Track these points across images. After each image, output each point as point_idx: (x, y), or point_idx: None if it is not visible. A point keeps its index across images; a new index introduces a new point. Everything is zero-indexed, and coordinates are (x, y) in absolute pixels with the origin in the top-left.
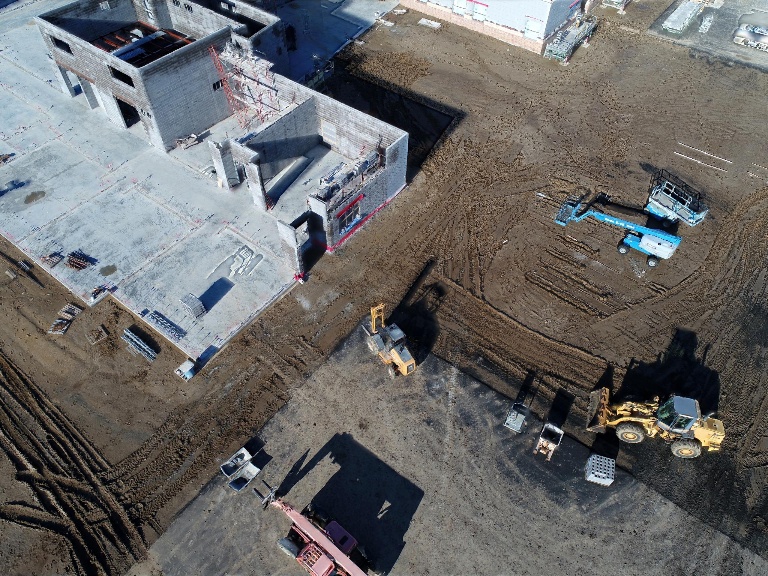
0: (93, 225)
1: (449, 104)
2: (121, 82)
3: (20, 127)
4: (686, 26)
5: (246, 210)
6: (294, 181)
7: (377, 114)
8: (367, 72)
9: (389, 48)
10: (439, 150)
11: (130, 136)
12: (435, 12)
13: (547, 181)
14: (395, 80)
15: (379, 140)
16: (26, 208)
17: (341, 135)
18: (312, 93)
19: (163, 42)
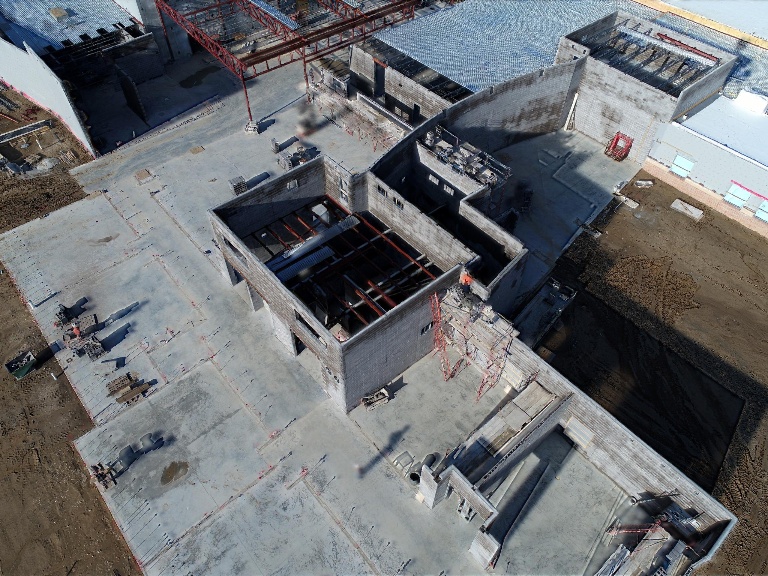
0: (245, 550)
1: (734, 371)
2: (308, 331)
3: (167, 331)
4: None
5: (456, 560)
6: (523, 507)
7: (631, 378)
8: (609, 289)
9: (635, 247)
10: (733, 472)
11: (300, 371)
12: (694, 192)
13: None
14: (650, 311)
15: (672, 492)
16: (162, 494)
17: (600, 447)
18: (571, 388)
19: (356, 236)
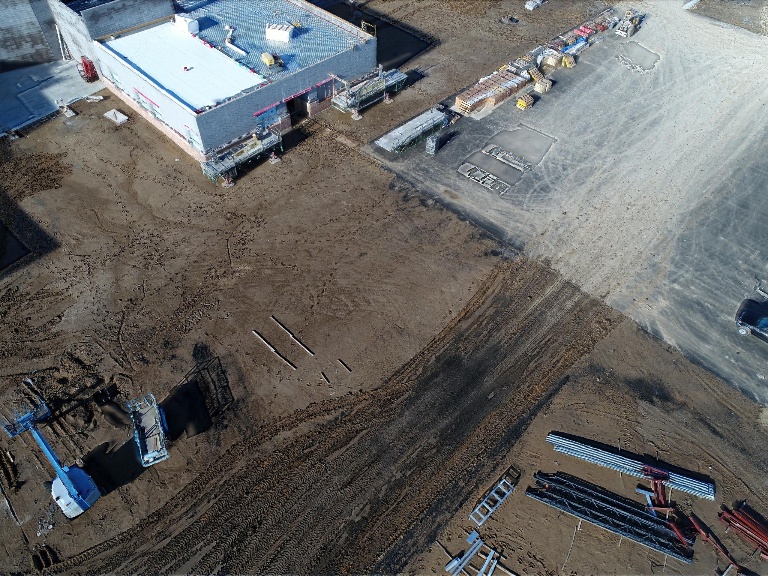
0: None
1: (42, 232)
2: None
3: None
4: (415, 143)
5: None
6: None
7: None
8: None
9: (43, 146)
10: None
11: None
12: (130, 103)
13: (57, 361)
14: (8, 192)
15: None
16: None
17: None
18: None
19: None
